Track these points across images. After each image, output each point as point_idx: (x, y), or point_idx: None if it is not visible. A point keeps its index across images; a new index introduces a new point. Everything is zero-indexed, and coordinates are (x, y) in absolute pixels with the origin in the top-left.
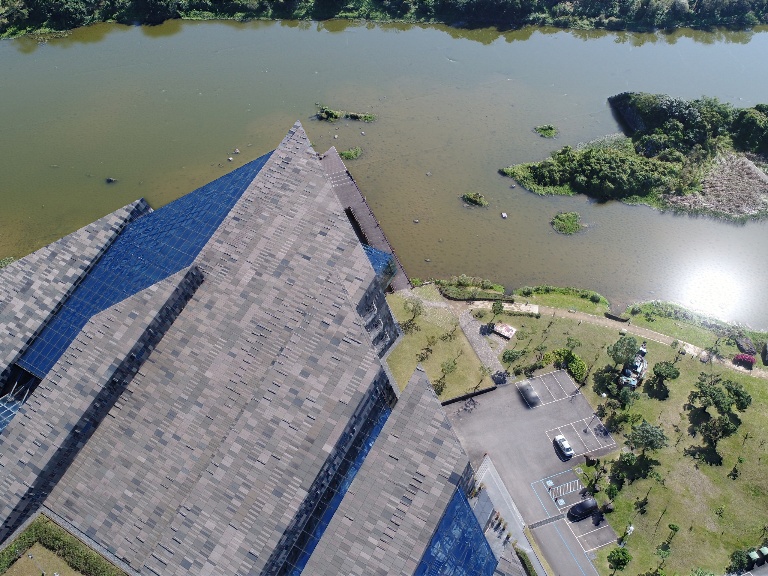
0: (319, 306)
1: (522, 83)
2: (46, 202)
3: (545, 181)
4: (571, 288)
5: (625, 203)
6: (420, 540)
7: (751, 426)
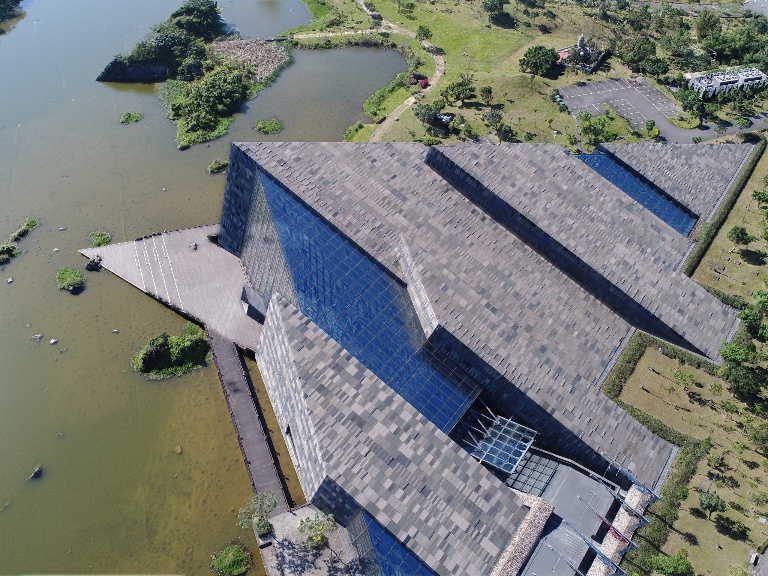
0: (462, 163)
1: (33, 119)
2: (55, 554)
3: (213, 126)
4: (347, 134)
5: (253, 98)
6: (601, 178)
7: (476, 91)
